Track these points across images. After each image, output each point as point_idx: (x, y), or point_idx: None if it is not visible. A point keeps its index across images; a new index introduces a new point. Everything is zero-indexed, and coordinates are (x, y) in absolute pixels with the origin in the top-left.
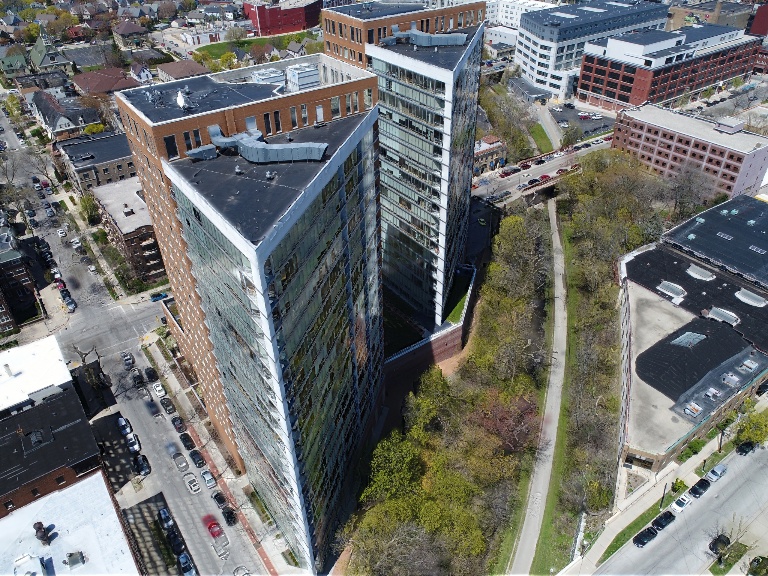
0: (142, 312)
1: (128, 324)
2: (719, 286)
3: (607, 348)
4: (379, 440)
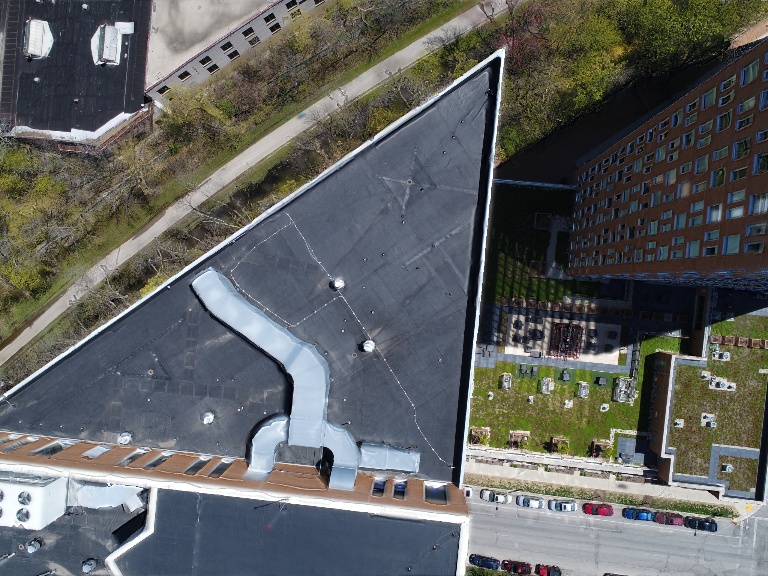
0: (729, 572)
1: (759, 557)
2: (49, 4)
3: (250, 77)
4: (618, 131)
